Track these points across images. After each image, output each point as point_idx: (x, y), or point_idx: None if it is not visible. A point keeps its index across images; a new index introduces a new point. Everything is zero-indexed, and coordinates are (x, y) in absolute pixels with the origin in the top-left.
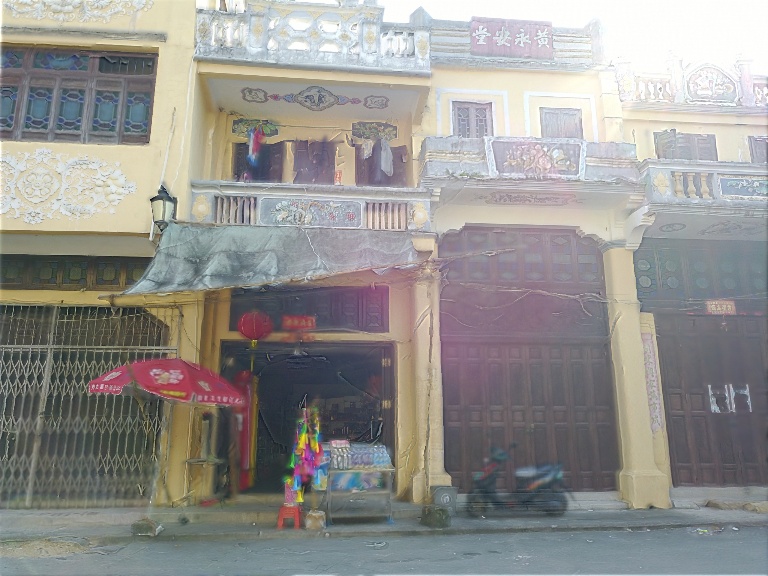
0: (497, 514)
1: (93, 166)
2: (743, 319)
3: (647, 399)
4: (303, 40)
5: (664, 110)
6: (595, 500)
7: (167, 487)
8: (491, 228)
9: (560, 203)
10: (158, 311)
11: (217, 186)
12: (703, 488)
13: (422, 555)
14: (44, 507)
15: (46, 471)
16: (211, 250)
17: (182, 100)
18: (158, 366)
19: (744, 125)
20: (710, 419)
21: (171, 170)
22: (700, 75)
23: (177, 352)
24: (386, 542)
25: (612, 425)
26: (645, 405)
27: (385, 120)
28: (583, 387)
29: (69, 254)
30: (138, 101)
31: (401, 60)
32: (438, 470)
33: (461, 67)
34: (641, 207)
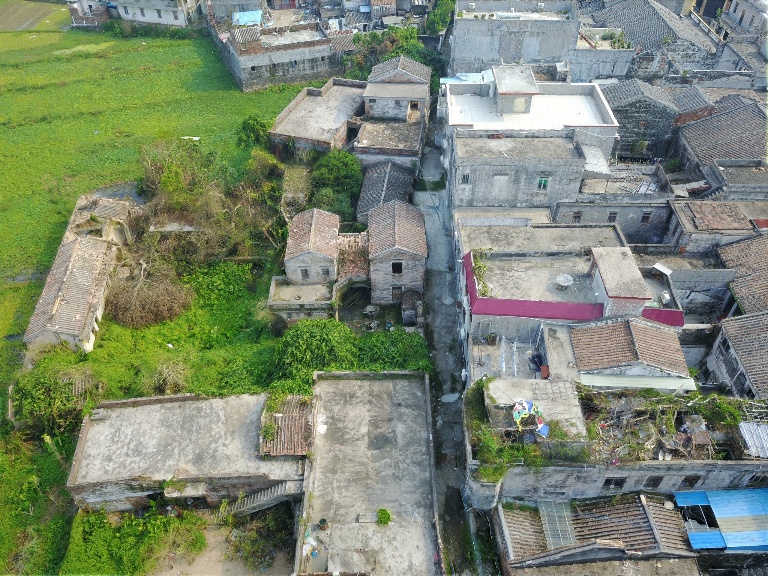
0: None
1: None
2: None
3: None
4: None
5: None
6: None
7: None
8: None
9: None
10: None
11: None
12: None
13: None
14: None
15: None
16: None
17: None
18: None
19: None
20: None
21: None
22: None
23: None
24: None
25: None
26: None
27: None
28: None
29: None
30: None
31: None
32: (701, 13)
33: None
34: None
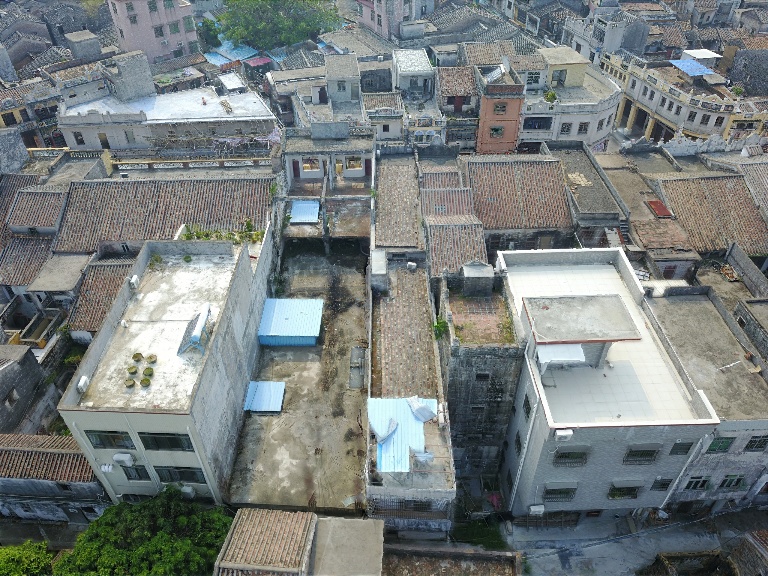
0: None
1: None
2: None
3: None
4: None
5: None
6: None
7: None
8: None
9: None
10: None
11: None
12: None
13: None
14: None
15: None
16: None
17: None
18: None
19: None
20: None
21: None
22: (6, 102)
23: None
24: None
25: None
26: None
27: None
28: None
29: None
30: None
31: None
32: None
33: None
34: None
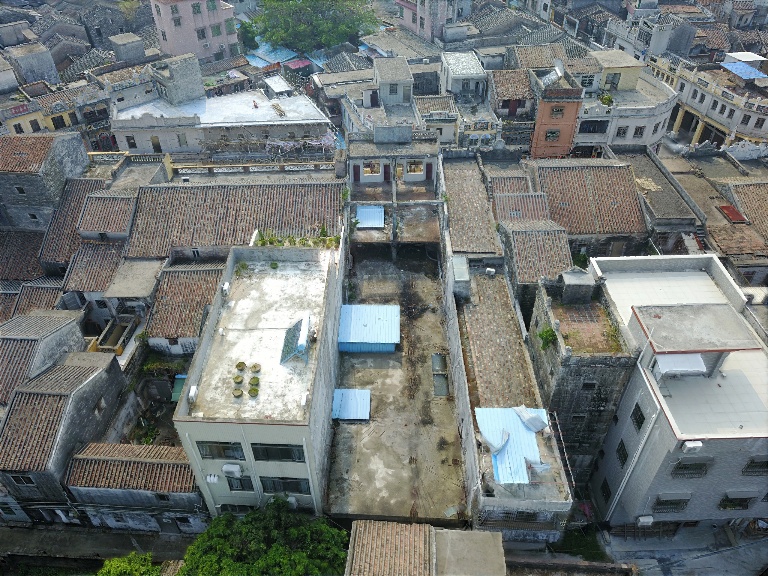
0: None
1: None
2: None
3: None
4: None
5: None
6: None
7: None
8: None
9: None
10: None
11: None
12: None
13: None
14: None
15: None
16: None
17: None
18: None
19: None
20: None
21: None
22: None
23: None
24: None
25: None
26: None
27: None
28: None
29: None
30: None
31: None
32: None
33: None
34: None
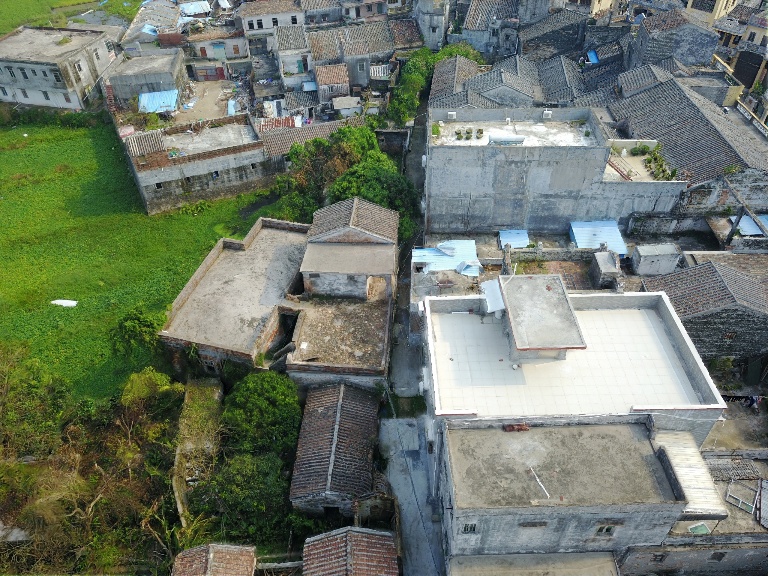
0: None
1: None
2: None
3: None
4: None
5: None
6: None
7: None
8: None
9: None
10: None
11: None
12: None
13: None
14: None
15: None
16: None
17: None
18: None
19: None
20: (767, 85)
21: None
22: None
23: None
24: None
25: None
26: None
27: None
28: (752, 76)
29: None
30: None
31: None
32: None
33: (754, 26)
34: None
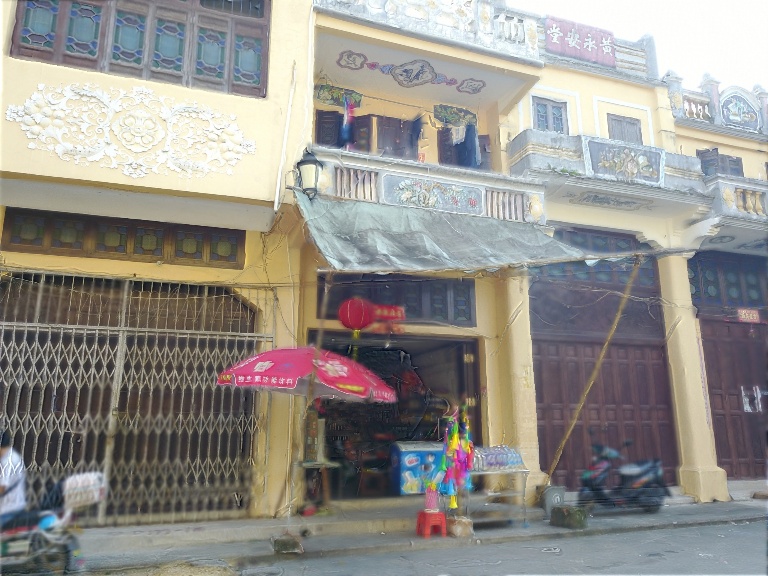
0: (594, 512)
1: (204, 116)
2: (764, 327)
3: (704, 399)
4: (420, 8)
5: (707, 130)
6: (664, 495)
7: (268, 495)
8: (565, 227)
9: (632, 208)
10: (250, 292)
11: (338, 156)
12: (742, 481)
13: (615, 559)
14: (122, 524)
15: (122, 480)
16: (356, 227)
17: (302, 53)
18: (311, 356)
19: (764, 152)
20: (744, 418)
21: (294, 132)
22: (731, 102)
23: (273, 340)
24: (557, 547)
25: (671, 423)
26: (703, 405)
27: (466, 106)
28: (646, 387)
29: (141, 218)
30: (248, 47)
31: (513, 46)
32: (537, 469)
33: None
34: (709, 218)
